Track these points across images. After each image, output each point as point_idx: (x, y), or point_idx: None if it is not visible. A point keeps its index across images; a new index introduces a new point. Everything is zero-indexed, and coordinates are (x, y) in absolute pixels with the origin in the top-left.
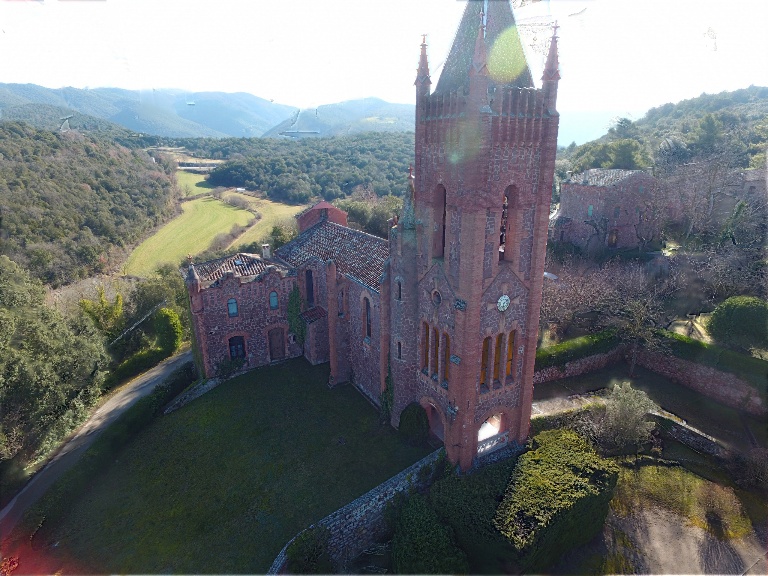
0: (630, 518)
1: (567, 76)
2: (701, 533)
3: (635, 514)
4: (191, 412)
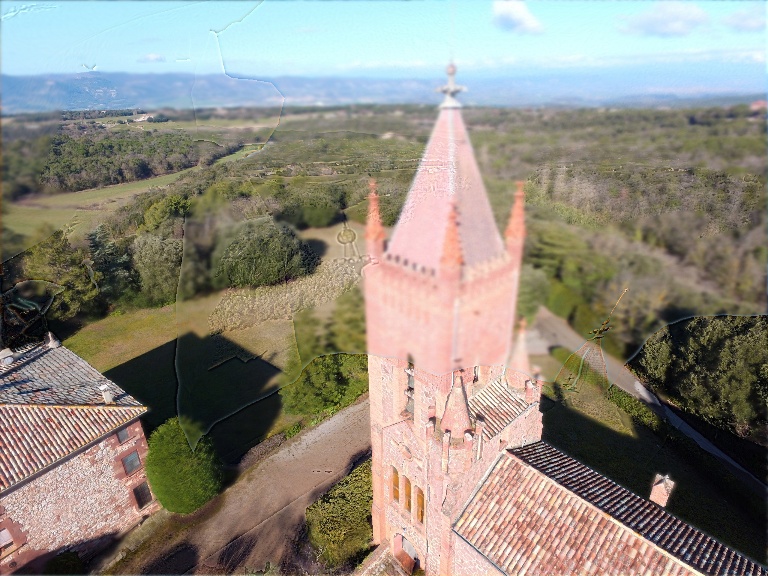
0: (288, 570)
1: (182, 411)
2: (235, 571)
3: (282, 575)
4: (746, 554)
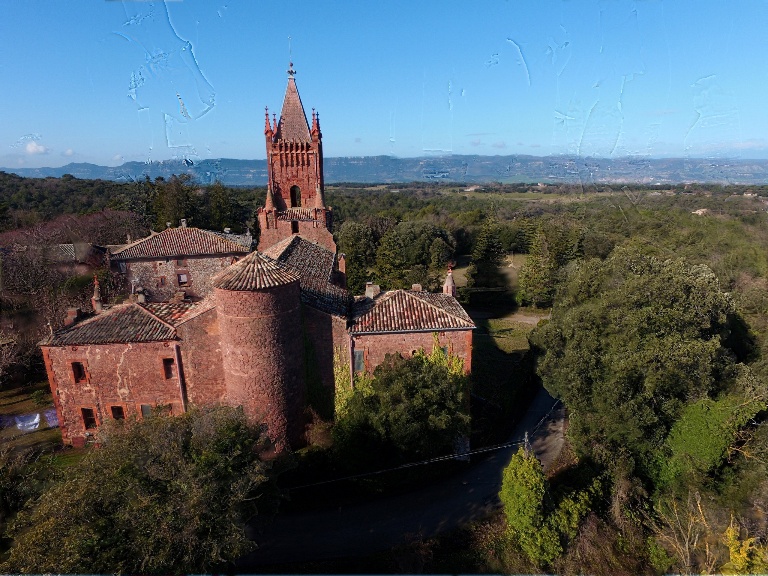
0: None
1: None
2: None
3: None
4: None
